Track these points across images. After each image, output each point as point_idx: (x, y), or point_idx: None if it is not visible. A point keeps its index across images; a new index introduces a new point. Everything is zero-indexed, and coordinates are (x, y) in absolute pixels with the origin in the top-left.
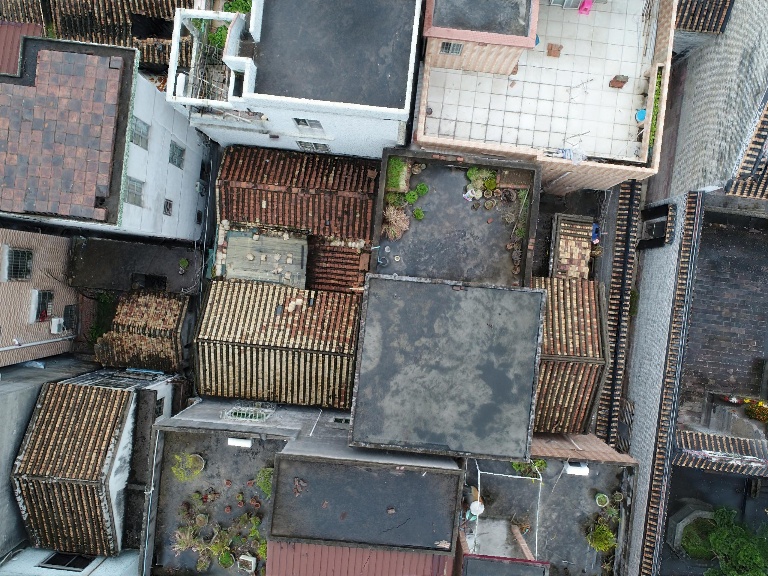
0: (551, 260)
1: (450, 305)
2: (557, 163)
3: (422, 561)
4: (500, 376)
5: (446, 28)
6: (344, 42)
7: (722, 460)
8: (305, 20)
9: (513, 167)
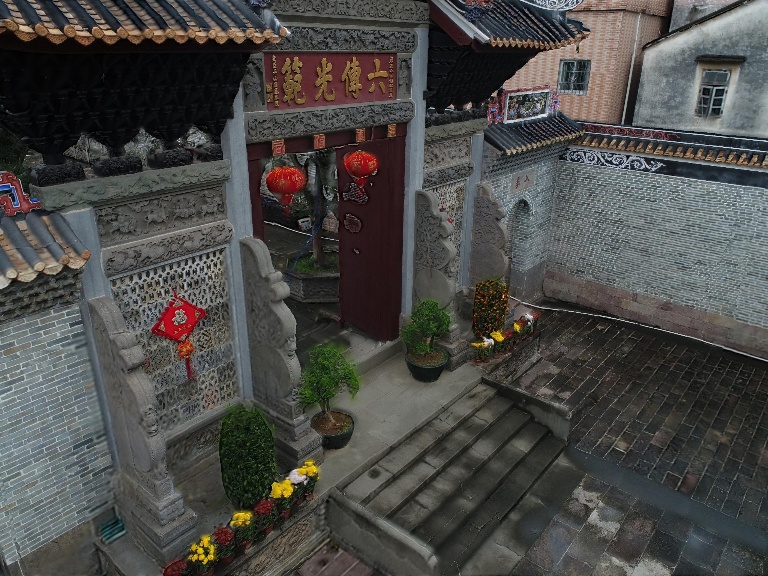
0: None
1: None
2: None
3: None
4: None
5: None
6: None
7: None
8: None
9: None
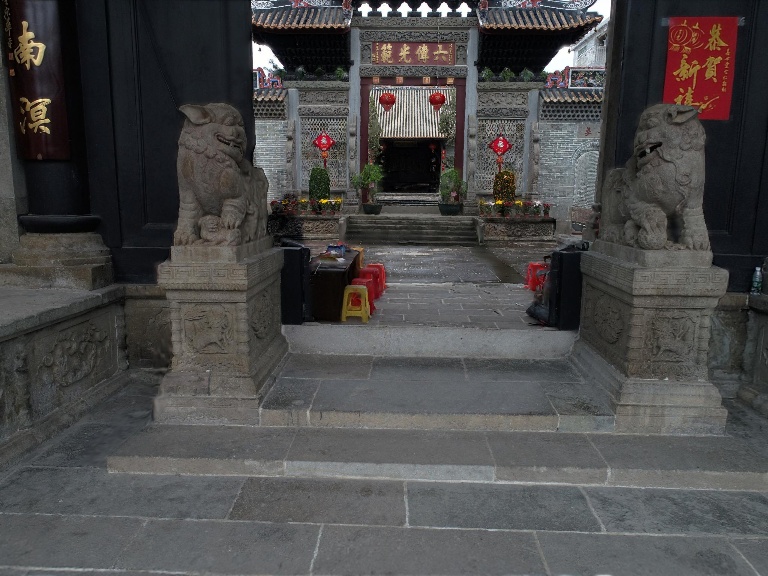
0: None
1: None
2: None
3: None
4: None
5: None
6: None
7: None
8: None
9: None
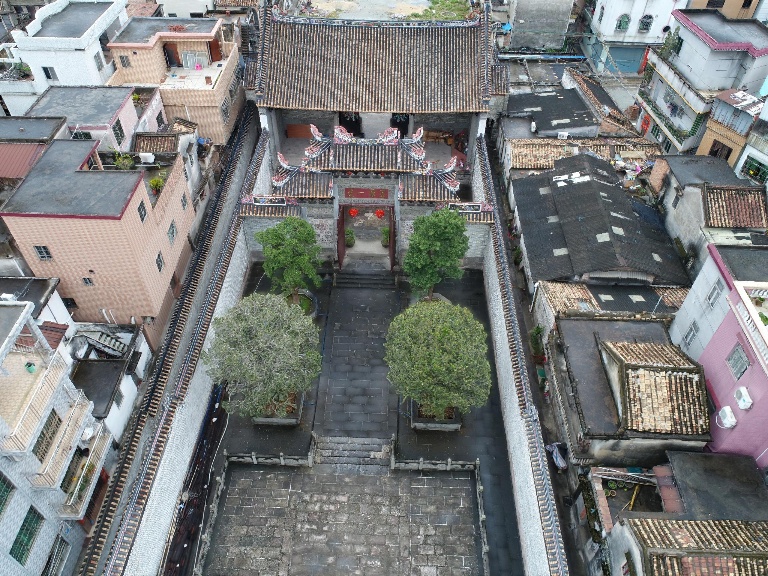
0: (168, 128)
1: (87, 92)
2: (170, 92)
3: (31, 148)
4: (103, 107)
5: (116, 43)
6: (67, 36)
7: (259, 195)
8: (53, 33)
9: (145, 88)
